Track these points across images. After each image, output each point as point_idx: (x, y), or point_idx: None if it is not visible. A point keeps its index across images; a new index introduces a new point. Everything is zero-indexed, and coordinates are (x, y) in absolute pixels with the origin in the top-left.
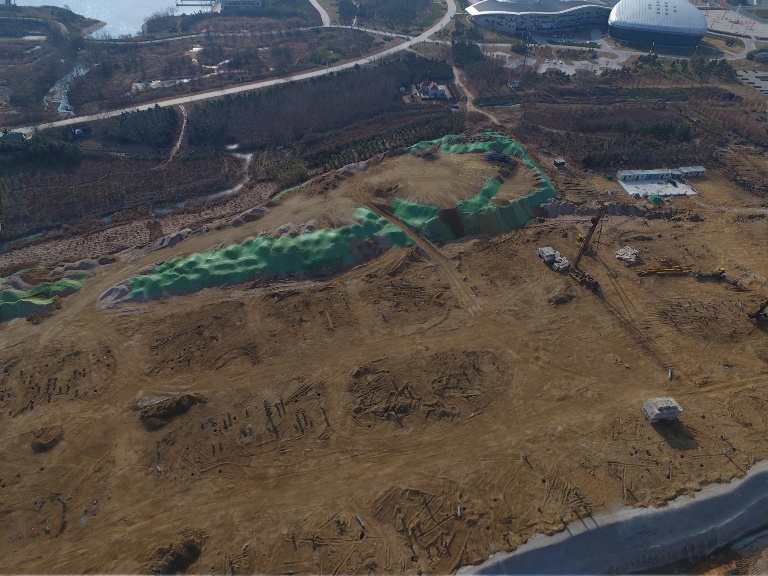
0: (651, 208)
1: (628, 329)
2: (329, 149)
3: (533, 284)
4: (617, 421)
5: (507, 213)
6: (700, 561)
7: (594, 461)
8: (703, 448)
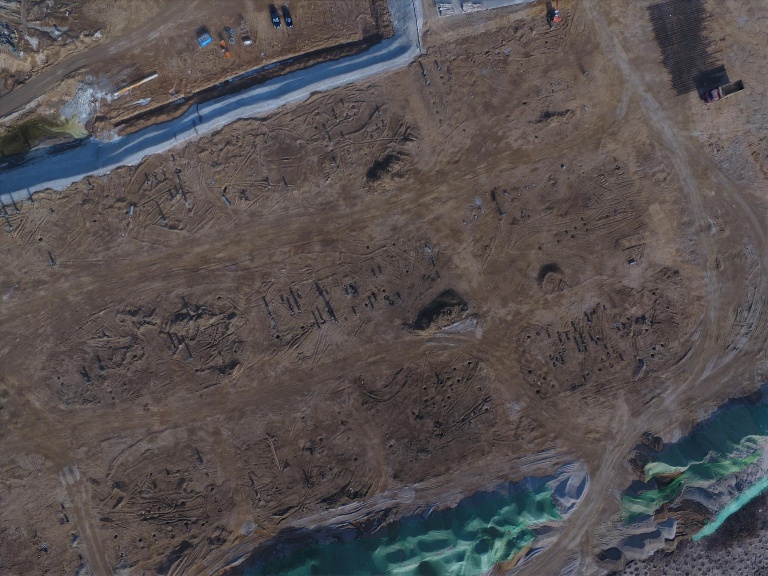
0: None
1: None
2: None
3: None
4: None
5: None
6: None
7: None
8: None
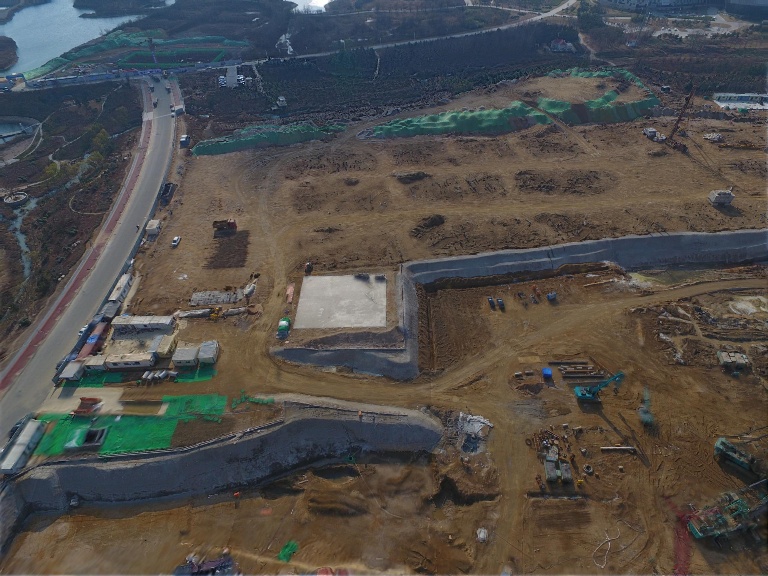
0: (738, 115)
1: (705, 169)
2: (485, 76)
3: (638, 146)
4: (689, 203)
5: (621, 110)
6: (733, 264)
7: (671, 215)
8: (746, 217)
